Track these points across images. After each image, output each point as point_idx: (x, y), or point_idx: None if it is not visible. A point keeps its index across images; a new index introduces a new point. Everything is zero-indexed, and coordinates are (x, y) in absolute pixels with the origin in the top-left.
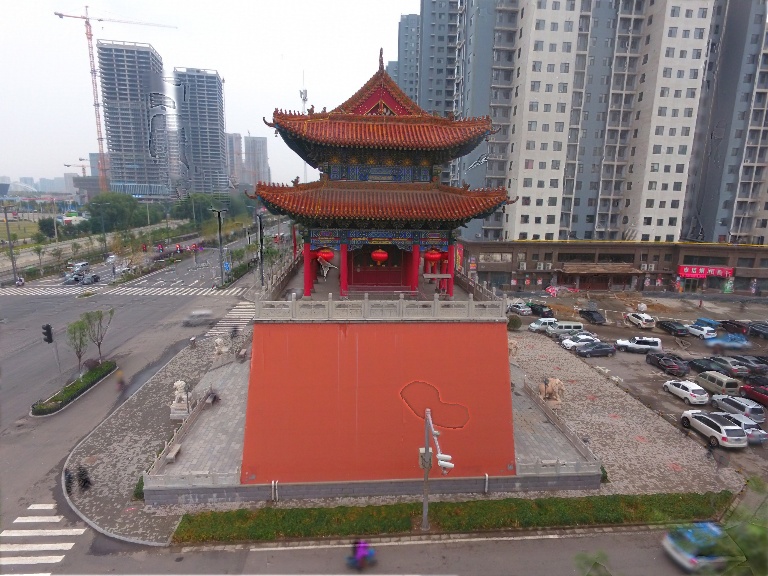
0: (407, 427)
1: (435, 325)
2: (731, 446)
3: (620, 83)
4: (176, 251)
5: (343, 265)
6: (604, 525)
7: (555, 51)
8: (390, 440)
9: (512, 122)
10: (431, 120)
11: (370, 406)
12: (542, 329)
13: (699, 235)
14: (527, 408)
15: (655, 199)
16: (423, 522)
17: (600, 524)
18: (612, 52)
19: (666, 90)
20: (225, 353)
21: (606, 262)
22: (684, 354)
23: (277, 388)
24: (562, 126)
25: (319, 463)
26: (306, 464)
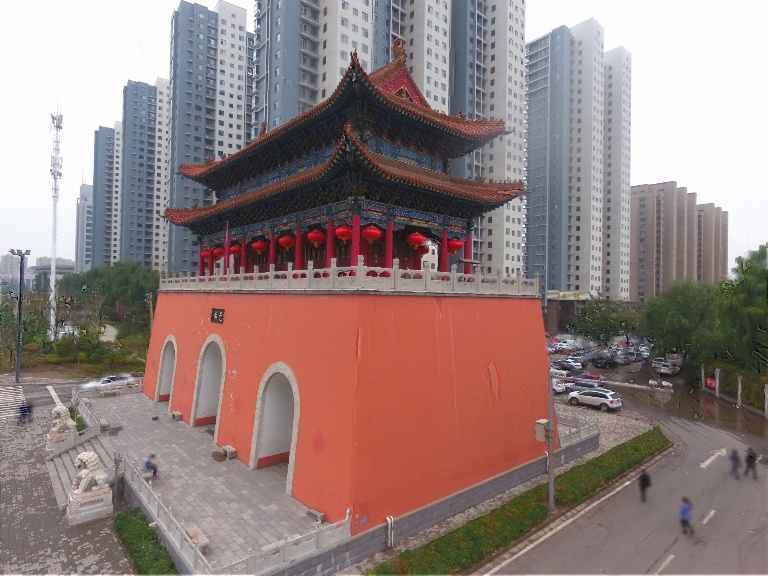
0: (492, 413)
1: (501, 300)
2: (617, 406)
3: None
4: None
5: (391, 245)
6: (638, 465)
7: None
8: (482, 431)
9: None
10: (441, 117)
11: (465, 393)
12: None
13: None
14: None
15: None
16: (551, 504)
17: (636, 466)
18: None
19: None
20: (73, 427)
21: None
22: (740, 276)
23: (384, 382)
24: None
25: (427, 478)
26: (416, 483)
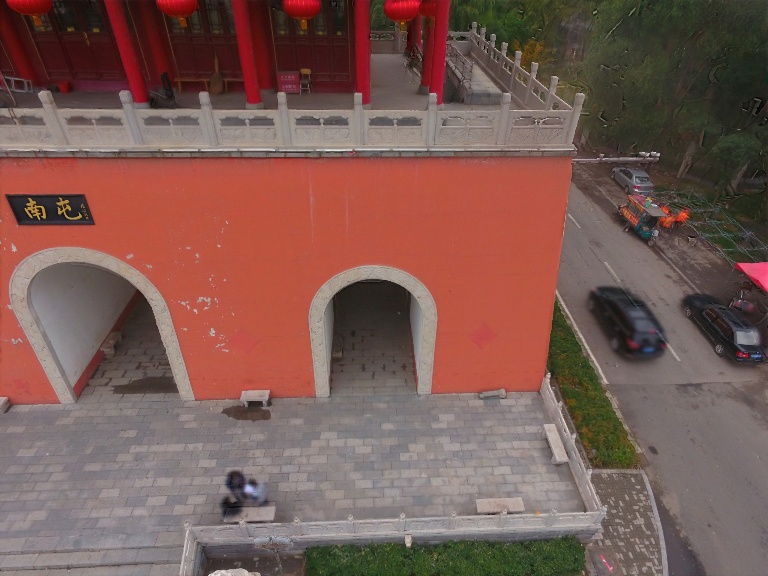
0: None
1: None
2: None
3: None
4: None
5: None
6: None
7: None
8: None
9: None
10: None
11: None
12: None
13: None
14: None
15: None
16: None
17: None
18: None
19: None
20: None
21: None
22: None
23: None
24: None
25: None
26: None
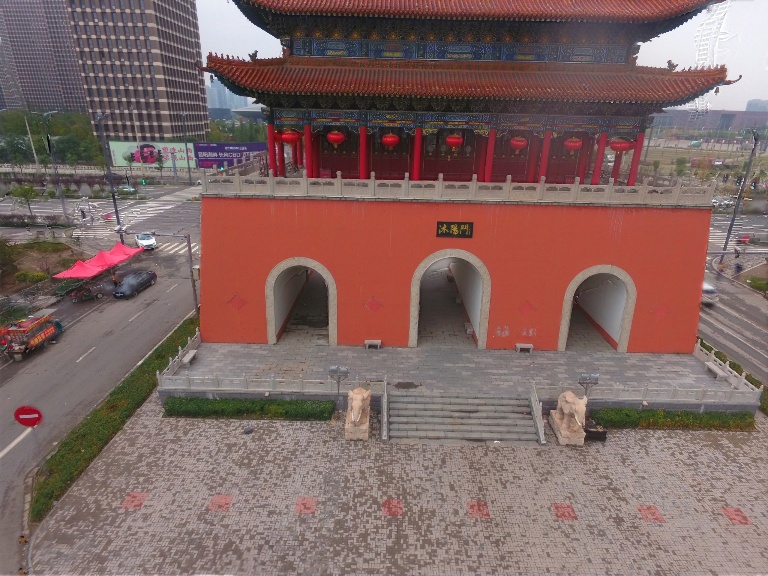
0: None
1: None
2: None
3: None
4: (750, 186)
5: None
6: None
7: None
8: None
9: None
10: None
11: None
12: None
13: None
14: (322, 379)
15: None
16: None
17: None
18: None
19: None
20: None
21: None
22: None
23: None
24: None
25: None
26: None
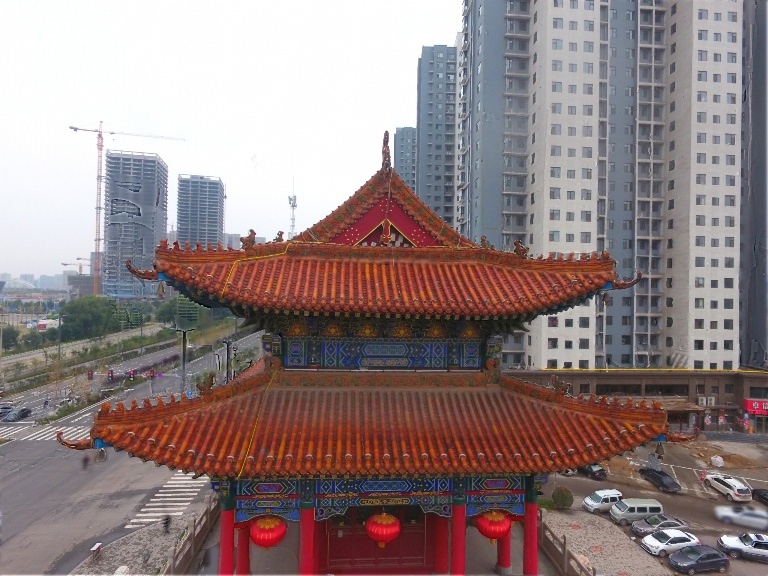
0: None
1: None
2: None
3: (645, 190)
4: (129, 378)
5: (305, 554)
6: None
7: (574, 156)
8: None
9: (529, 231)
10: (480, 255)
11: None
12: (603, 508)
13: (764, 362)
14: None
15: (704, 319)
16: None
17: None
18: (633, 158)
19: (702, 197)
20: None
21: (655, 395)
22: None
23: None
24: (589, 236)
25: None
26: None
